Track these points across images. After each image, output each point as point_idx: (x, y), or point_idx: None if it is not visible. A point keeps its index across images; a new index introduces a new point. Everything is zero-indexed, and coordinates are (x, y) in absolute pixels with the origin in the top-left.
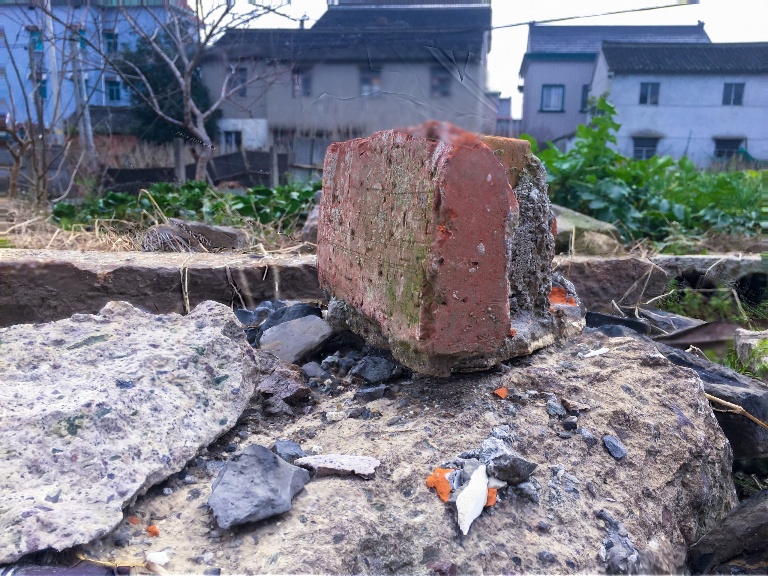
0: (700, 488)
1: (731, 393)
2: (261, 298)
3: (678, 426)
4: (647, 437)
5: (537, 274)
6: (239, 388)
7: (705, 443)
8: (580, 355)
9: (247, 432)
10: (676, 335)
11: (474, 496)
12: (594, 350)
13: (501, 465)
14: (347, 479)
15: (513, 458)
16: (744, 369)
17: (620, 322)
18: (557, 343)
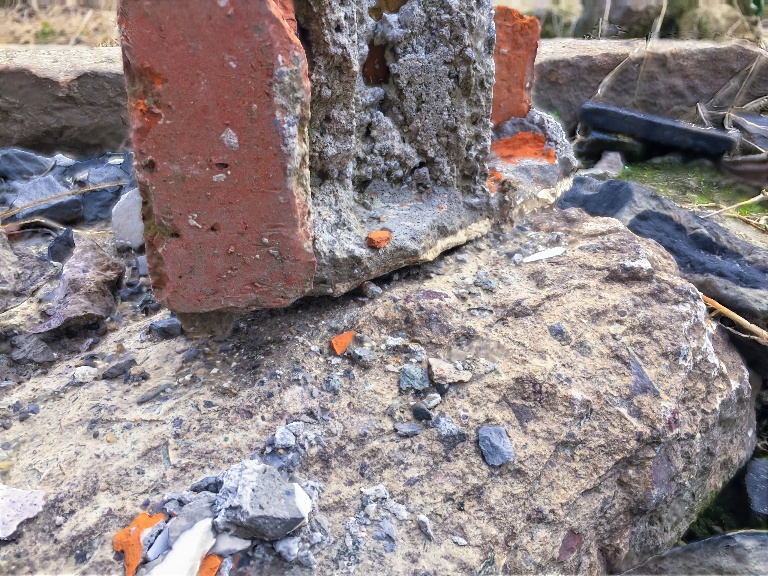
0: (647, 490)
1: (766, 305)
2: None
3: (629, 395)
4: (565, 420)
5: (459, 131)
6: None
7: (671, 422)
8: (516, 259)
9: None
10: (767, 157)
11: None
12: (546, 247)
13: (235, 521)
14: None
15: (246, 518)
16: None
17: (697, 136)
18: (497, 231)
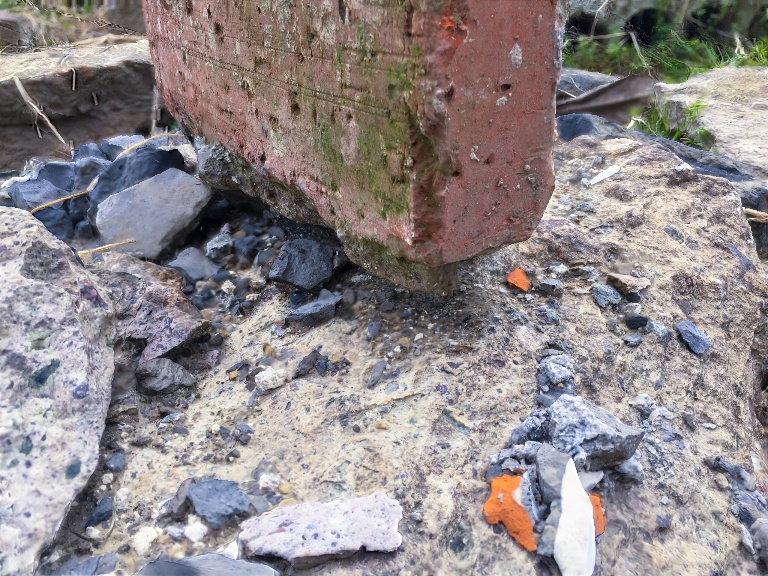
0: None
1: (743, 193)
2: (77, 115)
3: (741, 274)
4: (717, 304)
5: None
6: (86, 382)
7: None
8: (585, 182)
9: (122, 446)
10: (587, 98)
11: (581, 536)
12: (596, 169)
13: (597, 452)
14: (353, 563)
15: (621, 442)
16: (677, 134)
17: None
18: None
